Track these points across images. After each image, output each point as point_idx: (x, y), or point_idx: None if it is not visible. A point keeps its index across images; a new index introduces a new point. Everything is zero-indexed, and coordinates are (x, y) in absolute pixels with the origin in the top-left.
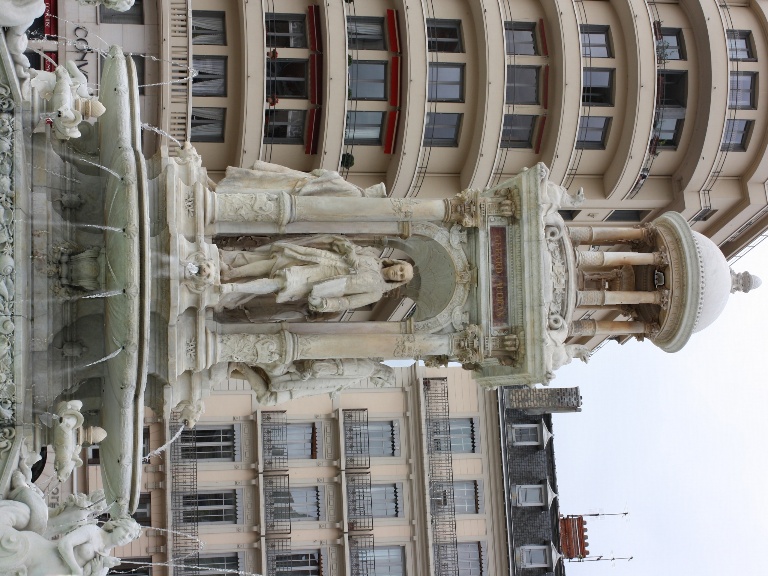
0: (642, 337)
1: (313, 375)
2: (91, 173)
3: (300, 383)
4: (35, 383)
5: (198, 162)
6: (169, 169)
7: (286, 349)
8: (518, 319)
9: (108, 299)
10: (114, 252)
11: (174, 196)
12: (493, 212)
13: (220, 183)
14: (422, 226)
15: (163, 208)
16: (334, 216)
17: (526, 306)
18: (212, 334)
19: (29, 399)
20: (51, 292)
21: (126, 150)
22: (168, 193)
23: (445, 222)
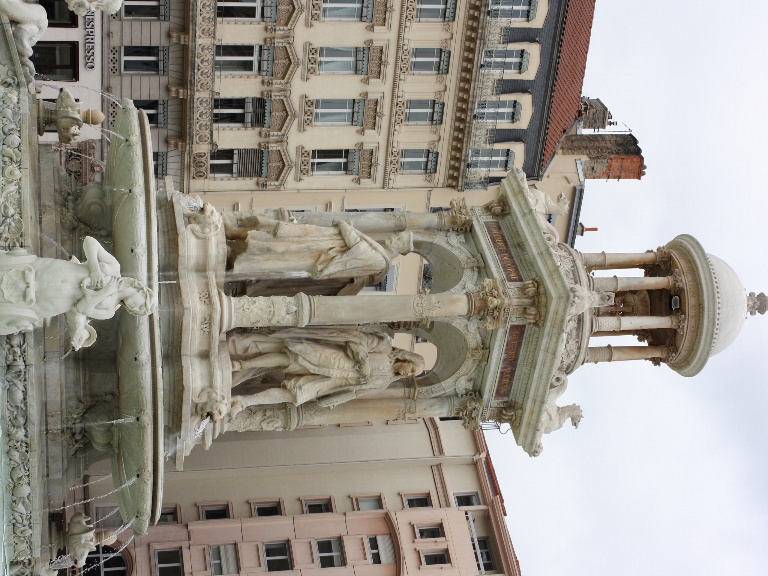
0: (644, 339)
1: None
2: None
3: None
4: (50, 493)
5: (218, 230)
6: (186, 312)
7: (290, 427)
8: (519, 398)
9: None
10: (128, 470)
11: (190, 331)
12: (516, 314)
13: (239, 257)
14: None
15: (178, 339)
16: (353, 320)
17: (529, 398)
18: None
19: (45, 519)
20: (65, 449)
21: (142, 367)
22: (184, 331)
23: None
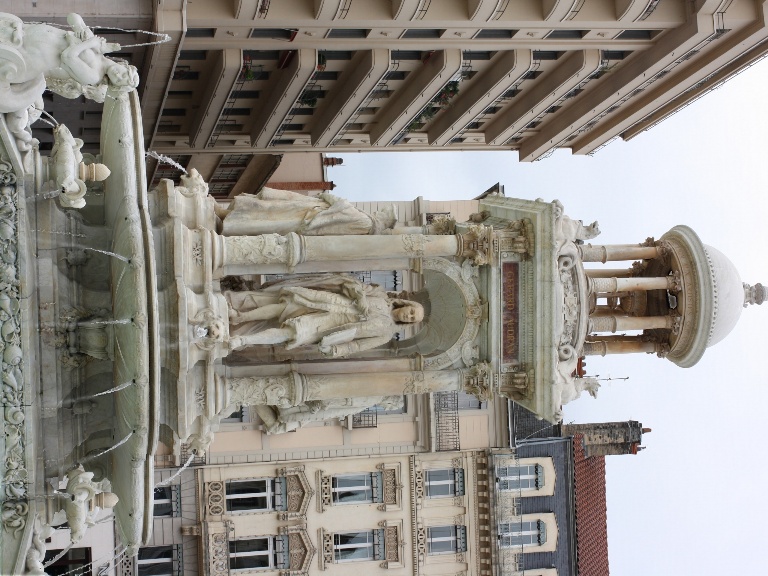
0: None
1: (322, 408)
2: (96, 213)
3: (309, 415)
4: (46, 447)
5: (205, 192)
6: (176, 221)
7: (295, 394)
8: (528, 356)
9: (117, 374)
10: (123, 336)
11: (182, 248)
12: (506, 248)
13: (228, 216)
14: (433, 261)
15: (171, 260)
16: (344, 257)
17: (537, 346)
18: (221, 380)
19: (40, 468)
20: (59, 363)
21: (132, 223)
22: (175, 246)
23: (457, 256)
